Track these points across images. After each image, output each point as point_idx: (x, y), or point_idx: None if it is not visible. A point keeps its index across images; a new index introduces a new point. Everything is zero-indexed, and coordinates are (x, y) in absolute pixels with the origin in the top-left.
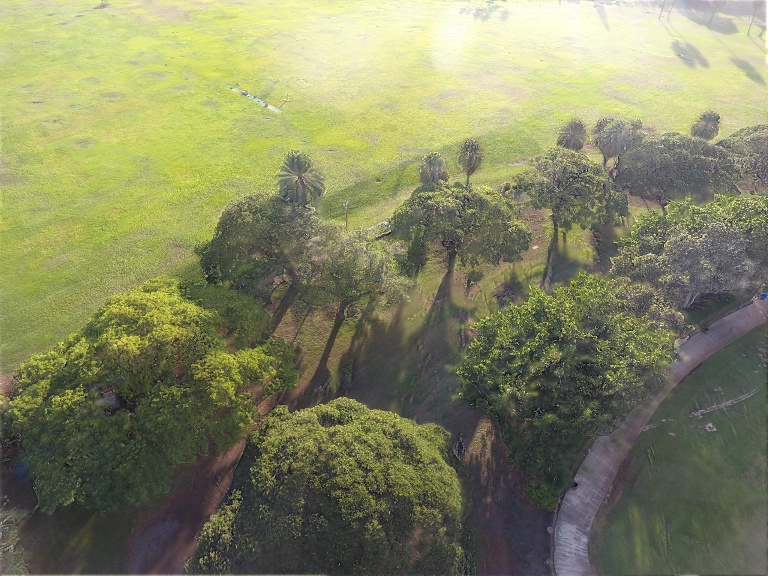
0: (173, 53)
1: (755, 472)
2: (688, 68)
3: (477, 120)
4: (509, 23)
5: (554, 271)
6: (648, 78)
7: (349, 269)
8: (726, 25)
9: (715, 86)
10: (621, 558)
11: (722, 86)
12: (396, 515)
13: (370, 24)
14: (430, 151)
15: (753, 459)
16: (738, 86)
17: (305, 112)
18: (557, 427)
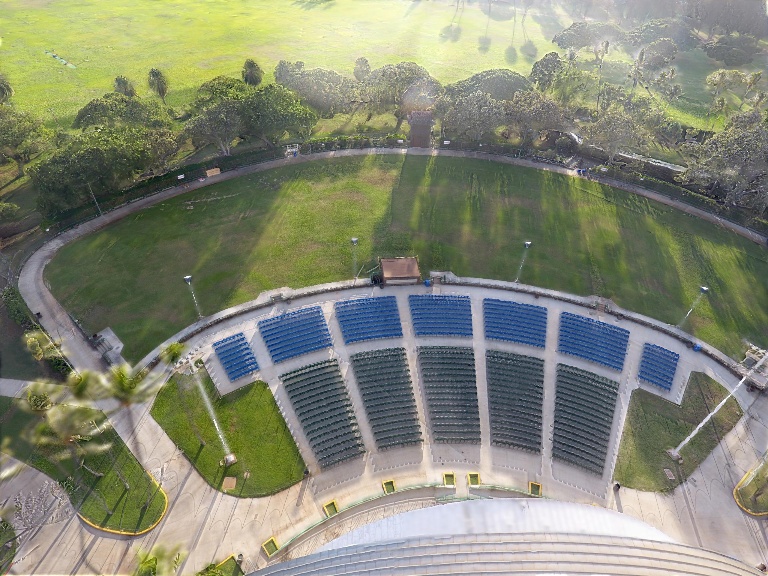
0: (15, 29)
1: (197, 224)
2: (438, 43)
3: (228, 73)
4: (326, 11)
5: (196, 153)
6: (397, 49)
7: (1, 131)
8: (507, 15)
9: (444, 54)
10: (76, 251)
11: (450, 54)
12: None
13: (205, 11)
14: (172, 91)
15: (202, 219)
16: (462, 54)
17: (94, 68)
18: (46, 183)
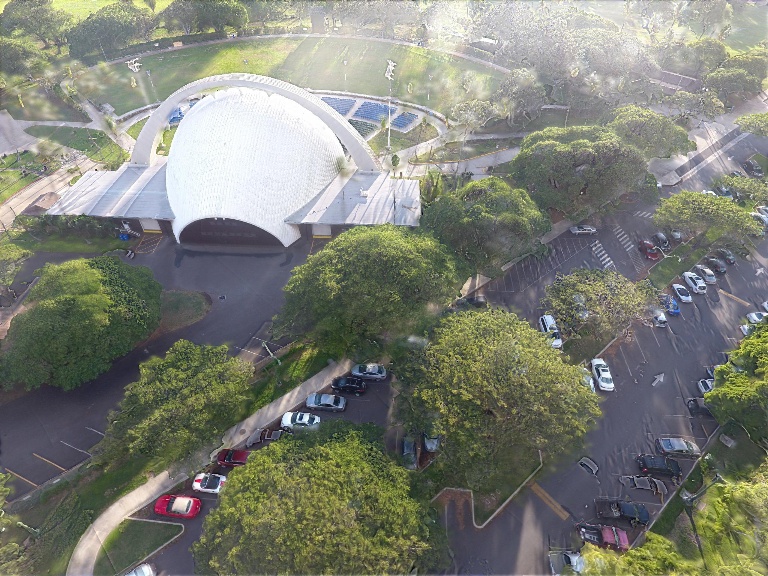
0: None
1: None
2: None
3: None
4: None
5: None
6: None
7: (47, 19)
8: None
9: None
10: None
11: None
12: (6, 46)
13: None
14: None
15: None
16: None
17: (109, 0)
18: (74, 37)
